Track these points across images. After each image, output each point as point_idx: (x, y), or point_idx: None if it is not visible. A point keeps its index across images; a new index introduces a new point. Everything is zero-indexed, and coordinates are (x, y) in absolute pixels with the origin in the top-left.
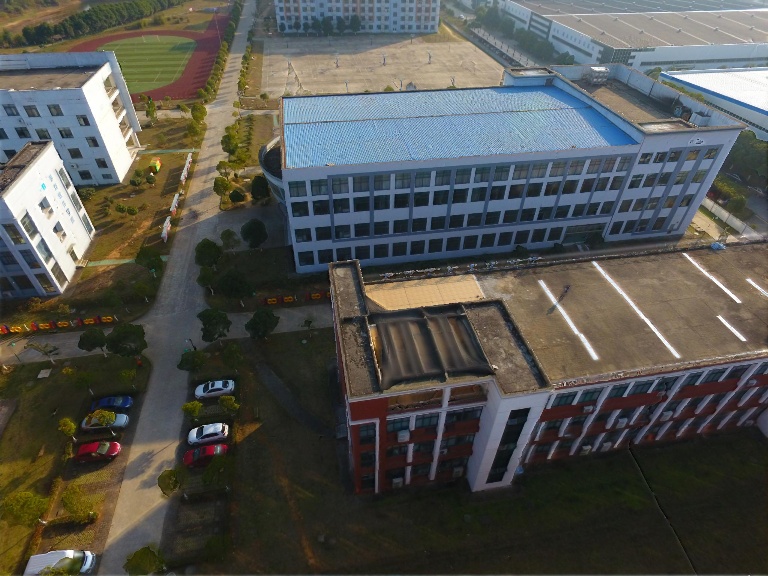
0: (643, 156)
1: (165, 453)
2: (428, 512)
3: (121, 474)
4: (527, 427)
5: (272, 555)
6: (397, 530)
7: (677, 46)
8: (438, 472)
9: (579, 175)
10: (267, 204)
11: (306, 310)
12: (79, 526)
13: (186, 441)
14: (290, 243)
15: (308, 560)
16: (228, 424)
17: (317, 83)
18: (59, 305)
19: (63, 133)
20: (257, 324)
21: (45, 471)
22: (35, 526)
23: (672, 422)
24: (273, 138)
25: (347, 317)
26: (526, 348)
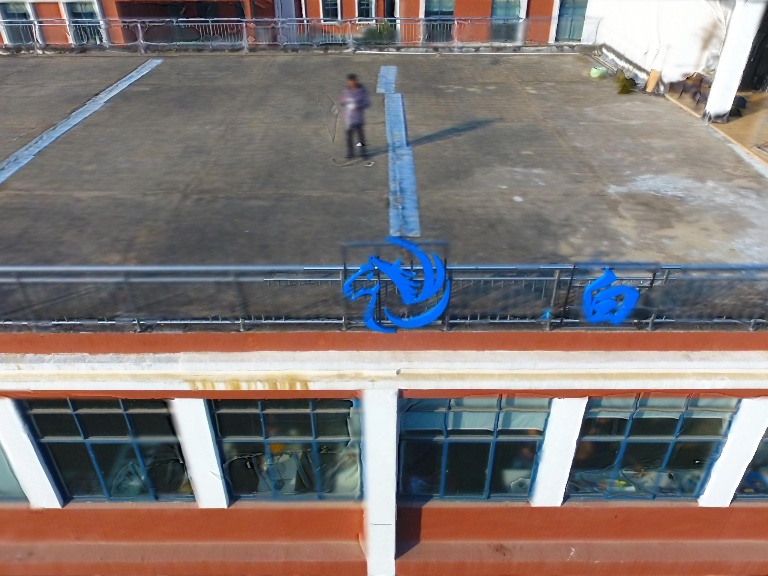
0: None
1: None
2: None
3: None
4: None
5: None
6: None
7: None
8: None
9: None
10: None
11: None
12: None
13: None
14: None
15: None
16: None
17: None
18: None
19: None
20: None
21: None
22: None
23: None
24: None
25: None
26: None
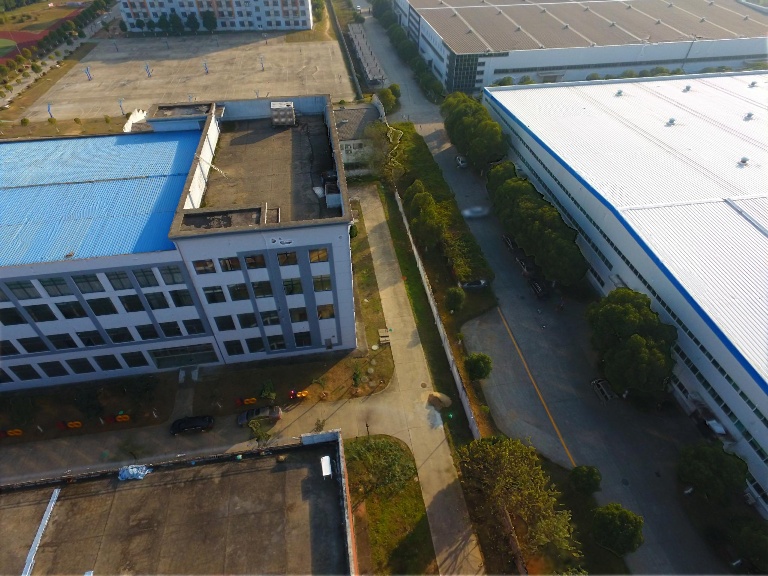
0: (198, 264)
1: None
2: None
3: None
4: None
5: None
6: None
7: (538, 49)
8: None
9: (103, 292)
10: None
11: None
12: None
13: None
14: None
15: None
16: None
17: (103, 99)
18: None
19: None
20: None
21: None
22: None
23: None
24: None
25: None
26: None
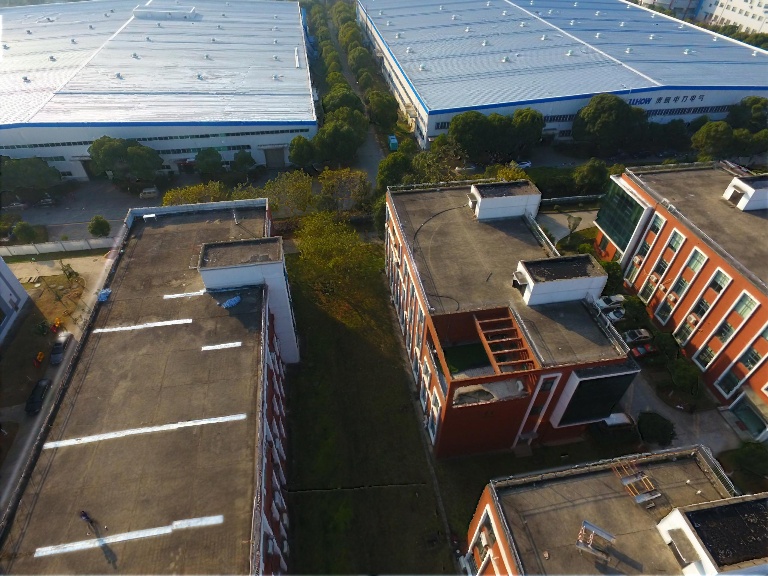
0: None
1: None
2: None
3: None
4: None
5: None
6: None
7: None
8: None
9: None
10: None
11: None
12: None
13: None
14: None
15: None
16: None
17: None
18: None
19: None
20: None
21: None
22: None
23: (280, 440)
24: None
25: None
26: None
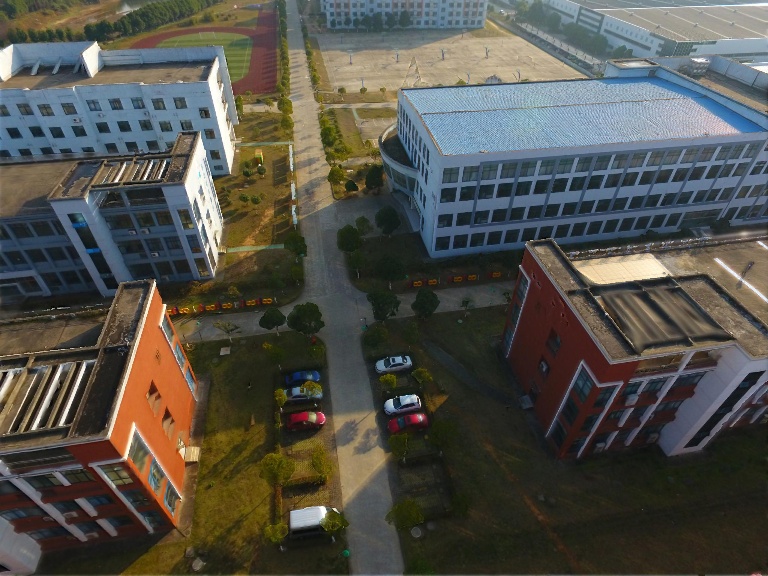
0: None
1: (367, 422)
2: (632, 474)
3: (333, 441)
4: (751, 390)
5: (502, 512)
6: (609, 490)
7: (738, 39)
8: (634, 438)
9: (708, 162)
10: (379, 193)
11: (451, 292)
12: (313, 487)
13: (383, 411)
14: (415, 230)
15: (537, 516)
16: (418, 396)
17: (383, 78)
18: (229, 287)
19: (184, 125)
20: (425, 303)
21: (262, 438)
22: (273, 487)
23: None
24: (386, 129)
25: (571, 290)
26: (752, 316)
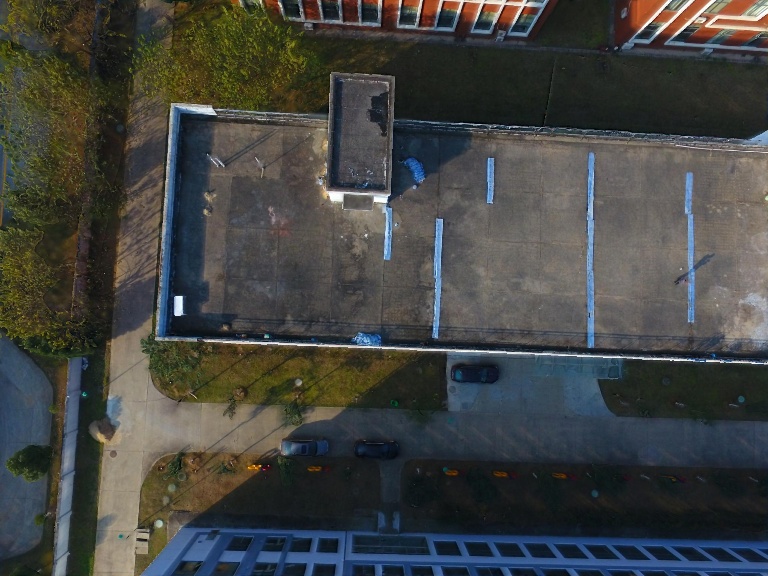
0: None
1: None
2: None
3: None
4: None
5: None
6: None
7: None
8: None
9: None
10: None
11: None
12: None
13: None
14: None
15: None
16: None
17: None
18: None
19: None
20: None
21: None
22: None
23: None
24: None
25: None
26: None
